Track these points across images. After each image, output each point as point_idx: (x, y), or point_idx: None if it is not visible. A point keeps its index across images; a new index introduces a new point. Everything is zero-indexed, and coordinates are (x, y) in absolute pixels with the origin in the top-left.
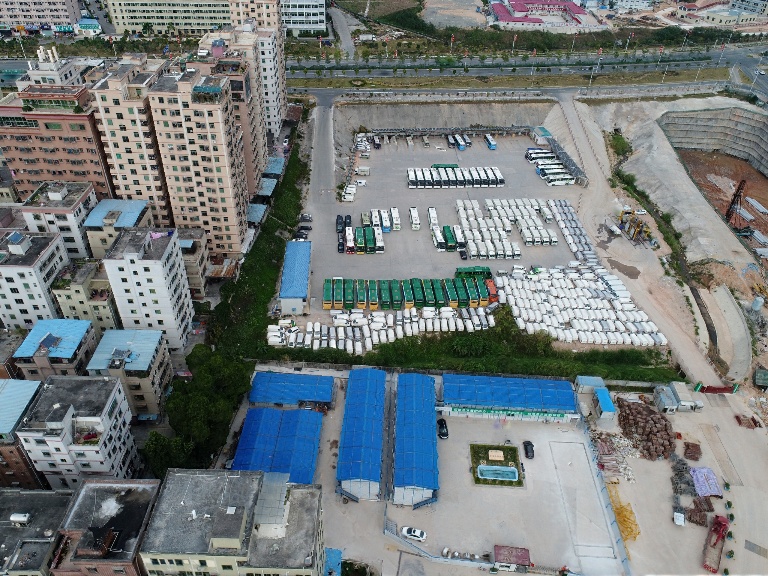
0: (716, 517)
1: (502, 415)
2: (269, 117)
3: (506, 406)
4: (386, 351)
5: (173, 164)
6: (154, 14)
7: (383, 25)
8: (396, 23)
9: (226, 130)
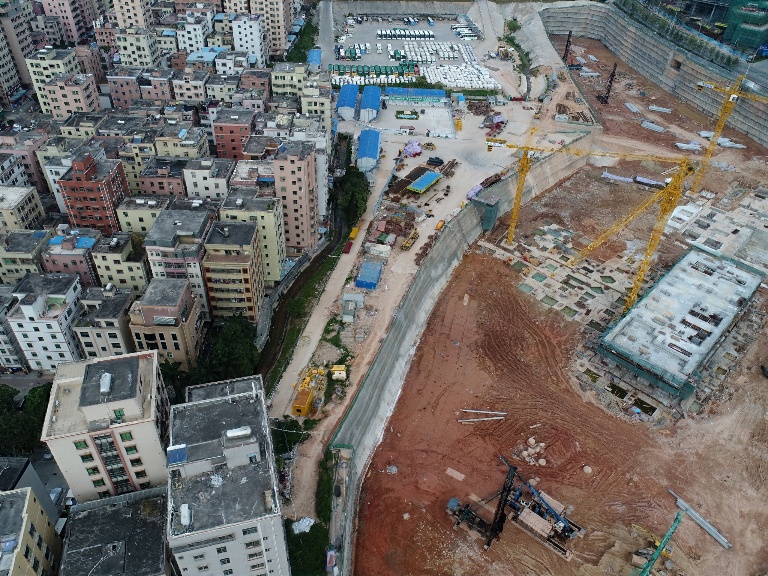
0: None
1: (412, 103)
2: None
3: (413, 95)
4: (360, 87)
5: None
6: None
7: None
8: None
9: None
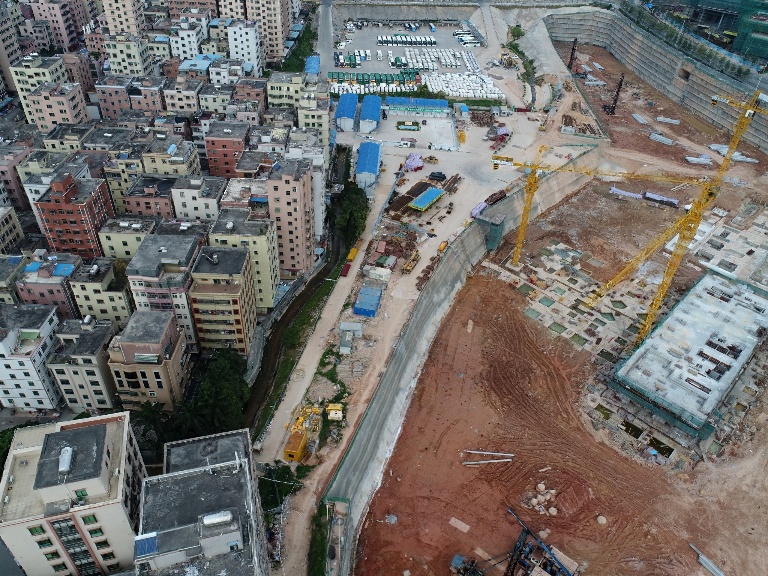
0: None
1: (414, 113)
2: (293, 3)
3: (415, 105)
4: (359, 96)
5: None
6: None
7: None
8: None
9: None
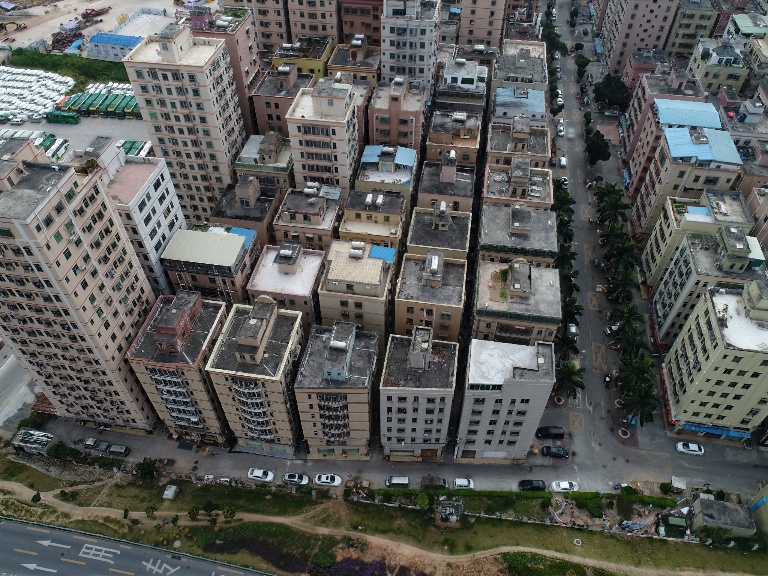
0: (84, 15)
1: None
2: None
3: None
4: None
5: None
6: None
7: None
8: None
9: None
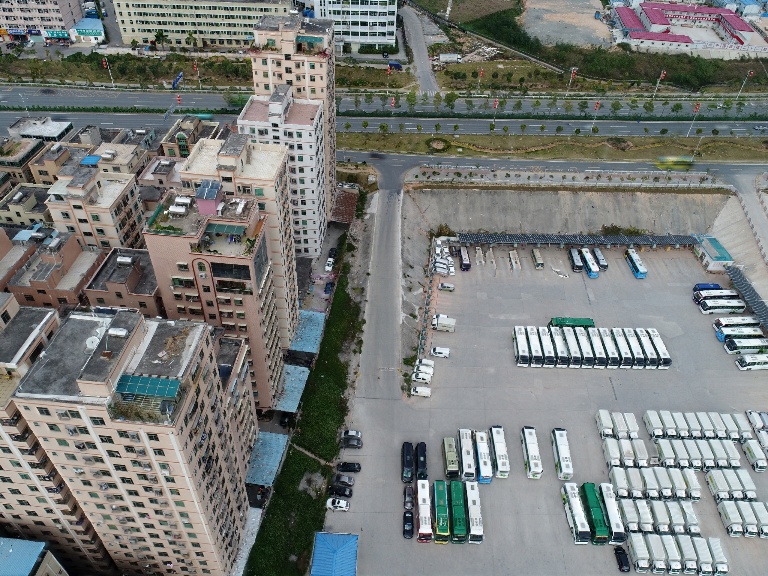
0: None
1: None
2: (306, 233)
3: None
4: None
5: (89, 489)
6: (171, 19)
7: (470, 34)
8: (487, 32)
9: (193, 445)
